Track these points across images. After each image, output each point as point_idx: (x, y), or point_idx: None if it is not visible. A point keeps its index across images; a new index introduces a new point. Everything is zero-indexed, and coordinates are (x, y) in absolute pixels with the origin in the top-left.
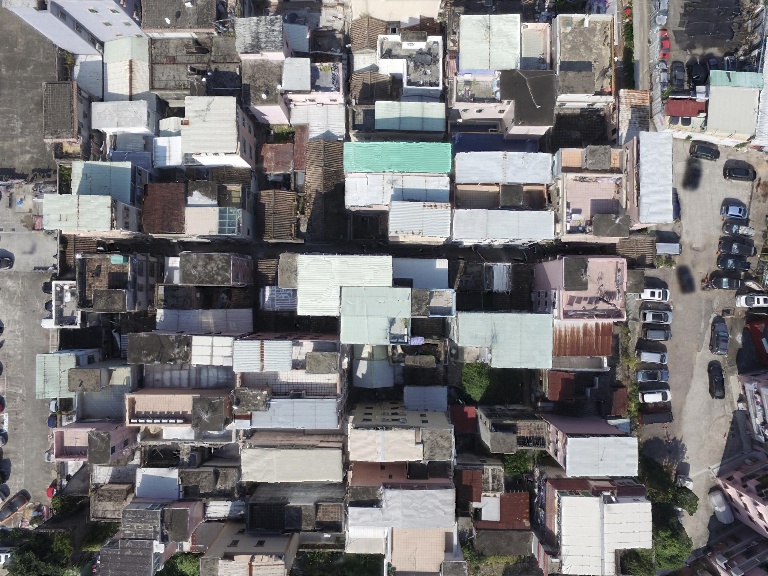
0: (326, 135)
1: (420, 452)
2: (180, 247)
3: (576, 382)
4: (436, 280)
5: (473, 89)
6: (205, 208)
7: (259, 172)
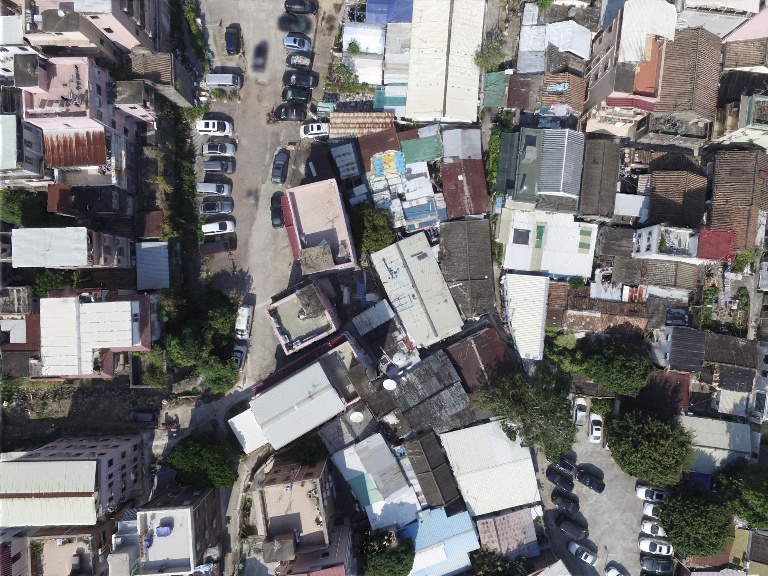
0: None
1: None
2: None
3: None
4: None
5: None
6: None
7: None
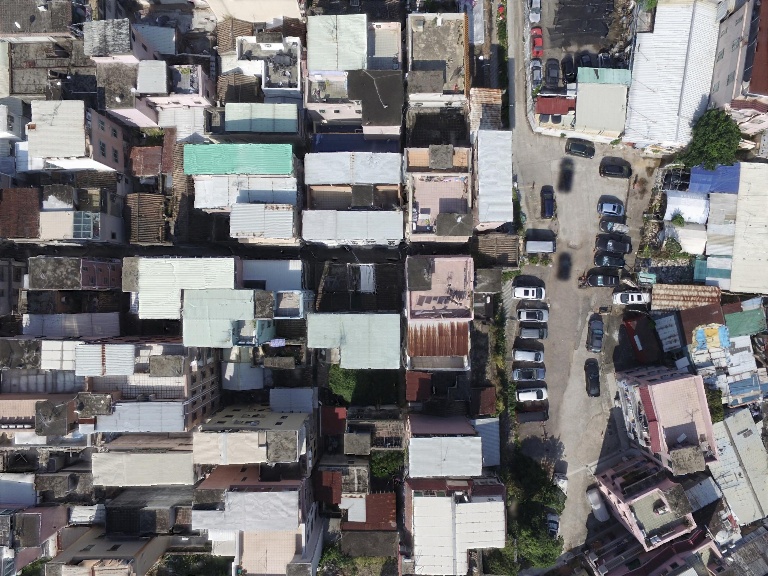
0: (193, 137)
1: (264, 454)
2: (55, 251)
3: (439, 382)
4: (289, 282)
5: (328, 90)
6: (59, 212)
7: (131, 175)
